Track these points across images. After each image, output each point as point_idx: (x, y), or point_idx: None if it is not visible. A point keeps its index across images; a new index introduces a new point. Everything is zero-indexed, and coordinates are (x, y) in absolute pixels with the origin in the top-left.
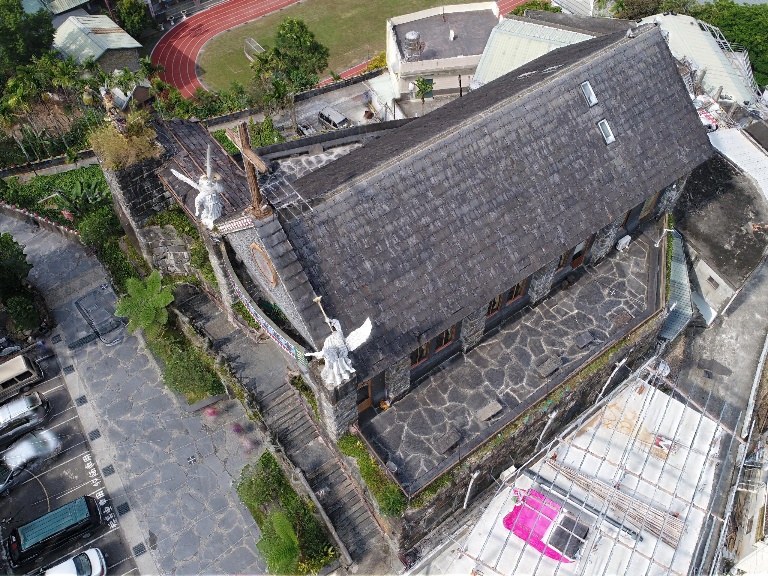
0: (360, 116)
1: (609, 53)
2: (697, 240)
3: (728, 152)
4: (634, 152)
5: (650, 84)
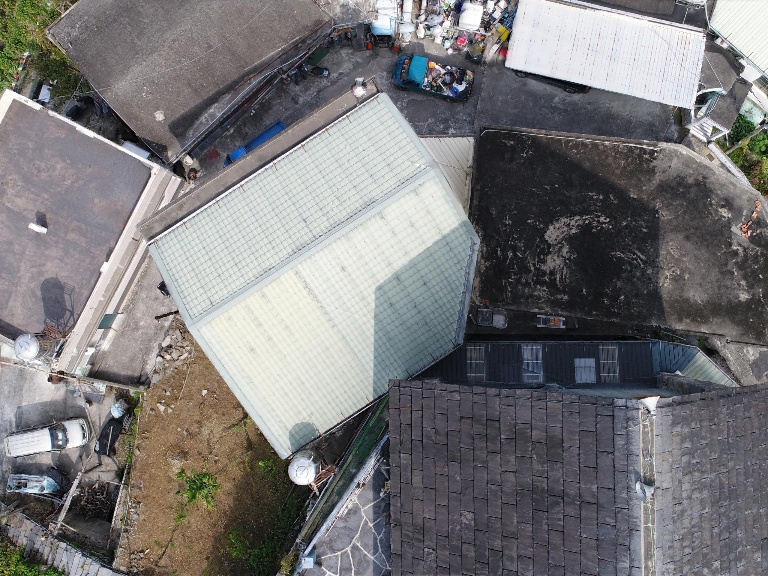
0: (46, 385)
1: (657, 566)
2: (707, 323)
3: (559, 62)
4: (757, 569)
5: (708, 480)
